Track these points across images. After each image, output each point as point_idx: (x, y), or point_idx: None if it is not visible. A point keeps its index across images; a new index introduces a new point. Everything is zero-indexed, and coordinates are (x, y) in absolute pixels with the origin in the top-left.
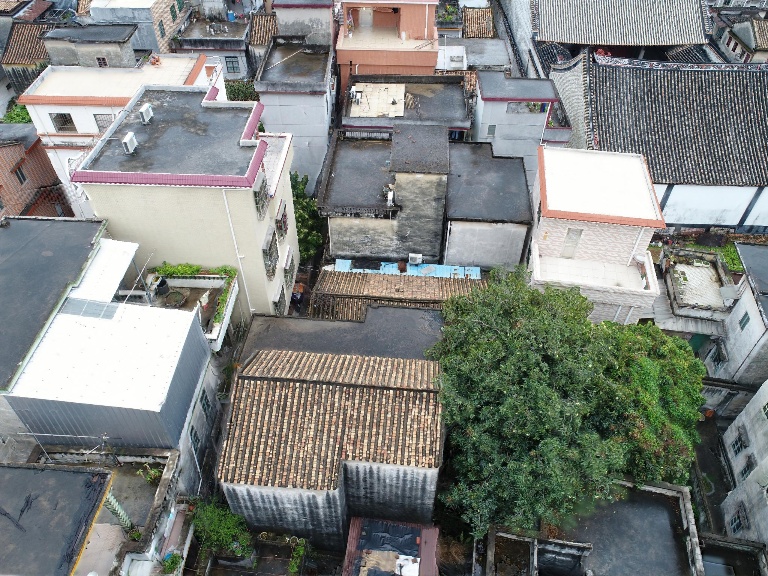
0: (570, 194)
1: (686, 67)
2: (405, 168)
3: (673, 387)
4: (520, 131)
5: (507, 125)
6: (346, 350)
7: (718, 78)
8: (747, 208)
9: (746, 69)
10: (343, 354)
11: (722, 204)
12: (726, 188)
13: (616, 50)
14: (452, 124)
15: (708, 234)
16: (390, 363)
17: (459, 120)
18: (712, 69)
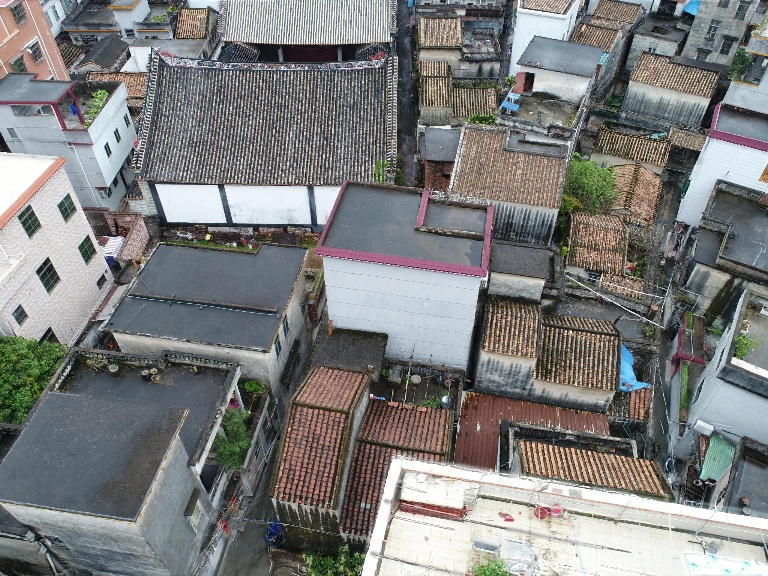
0: None
1: (257, 67)
2: None
3: None
4: (41, 134)
5: (24, 128)
6: None
7: (289, 78)
8: (310, 207)
9: (317, 68)
10: None
11: (283, 204)
12: (276, 188)
13: (322, 49)
14: None
15: (282, 234)
16: None
17: None
18: (283, 69)
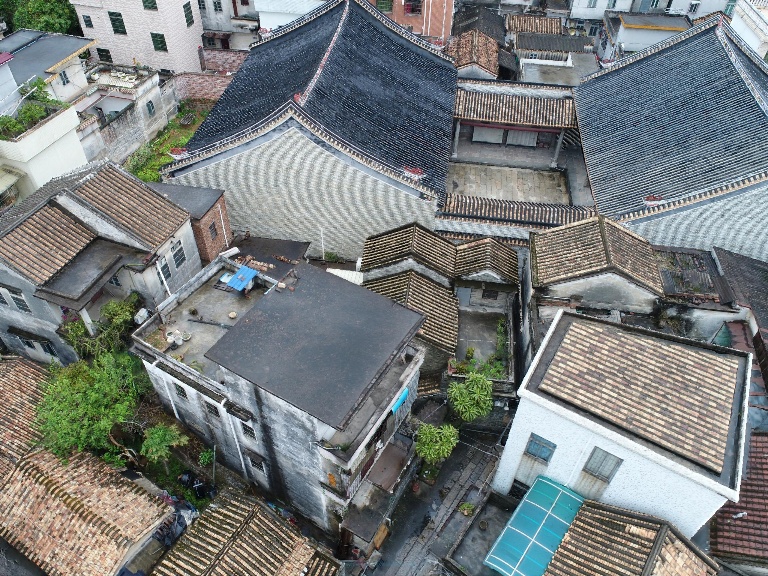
0: None
1: None
2: None
3: (23, 6)
4: None
5: None
6: None
7: None
8: None
9: None
10: None
11: None
12: None
13: None
14: None
15: None
16: None
17: None
18: None
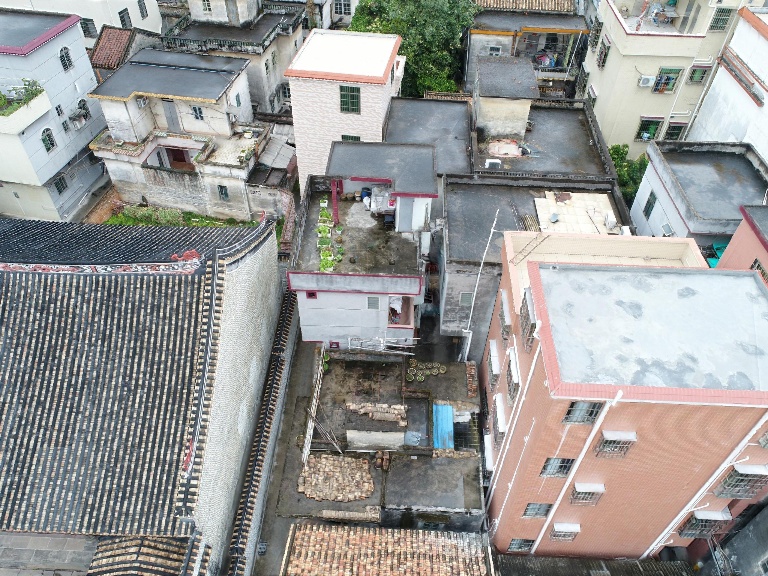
0: (374, 47)
1: None
2: (517, 58)
3: None
4: None
5: None
6: (527, 18)
7: None
8: None
9: None
10: (528, 17)
11: None
12: None
13: None
14: (467, 180)
15: None
16: (501, 1)
17: (459, 174)
18: None
